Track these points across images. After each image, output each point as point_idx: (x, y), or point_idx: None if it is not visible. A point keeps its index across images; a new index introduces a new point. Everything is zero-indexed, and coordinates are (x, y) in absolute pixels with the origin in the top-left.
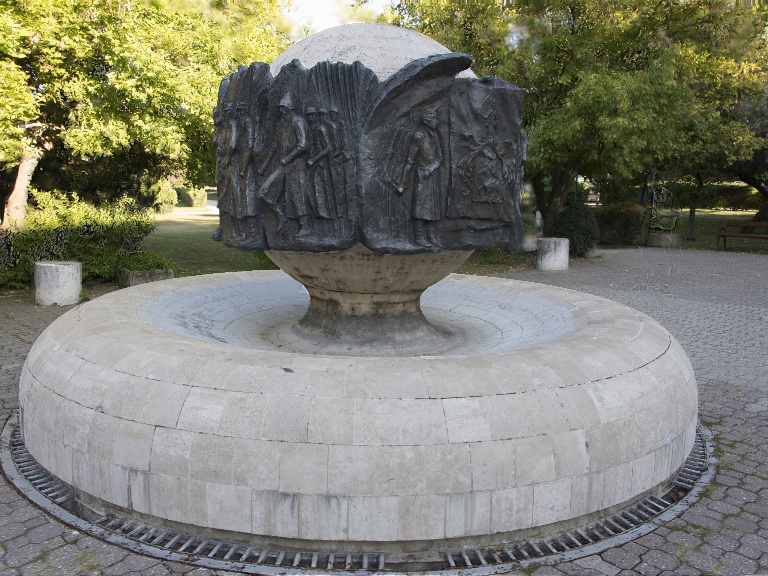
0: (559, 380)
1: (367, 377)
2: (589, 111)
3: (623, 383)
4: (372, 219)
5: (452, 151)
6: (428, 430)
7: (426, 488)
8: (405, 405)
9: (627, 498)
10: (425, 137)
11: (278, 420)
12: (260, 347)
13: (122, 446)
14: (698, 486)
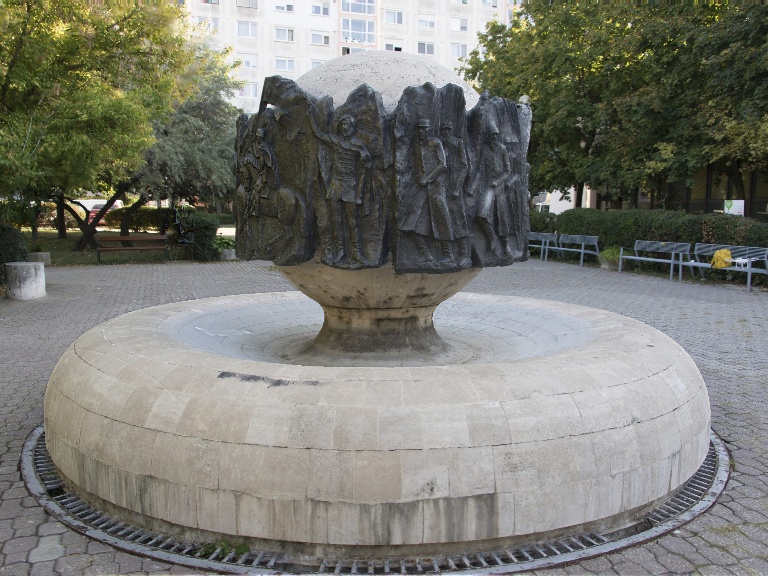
0: None
1: (662, 338)
2: (97, 125)
3: None
4: None
5: None
6: None
7: None
8: None
9: None
10: None
11: None
12: None
13: (666, 440)
14: None
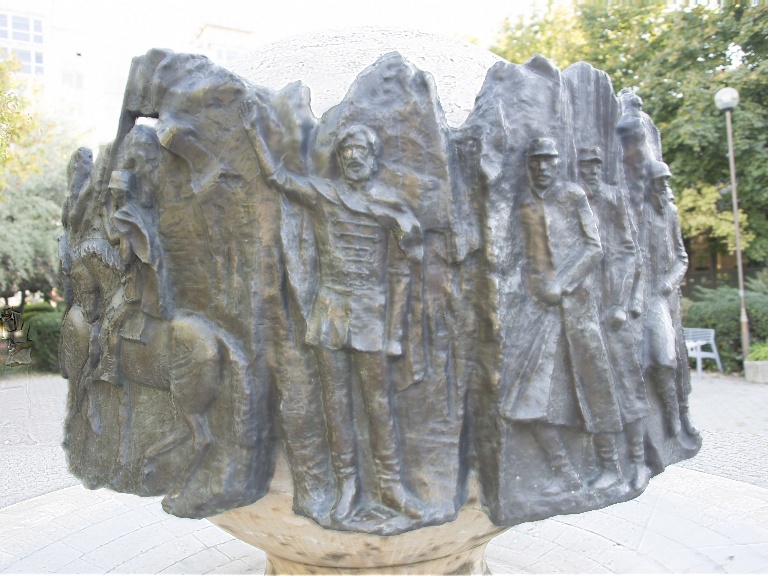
0: None
1: None
2: None
3: None
4: None
5: None
6: None
7: None
8: None
9: None
10: None
11: None
12: None
13: None
14: None
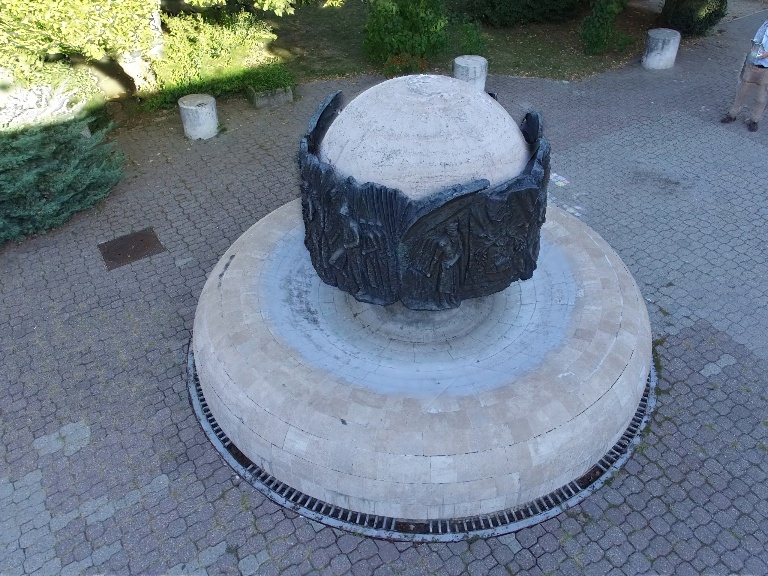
0: (511, 439)
1: (389, 435)
2: None
3: (559, 434)
4: (408, 291)
5: (471, 245)
6: (420, 476)
7: (417, 502)
8: (408, 460)
9: (548, 493)
10: (448, 243)
11: (336, 459)
12: (341, 320)
13: (256, 446)
14: (610, 471)
